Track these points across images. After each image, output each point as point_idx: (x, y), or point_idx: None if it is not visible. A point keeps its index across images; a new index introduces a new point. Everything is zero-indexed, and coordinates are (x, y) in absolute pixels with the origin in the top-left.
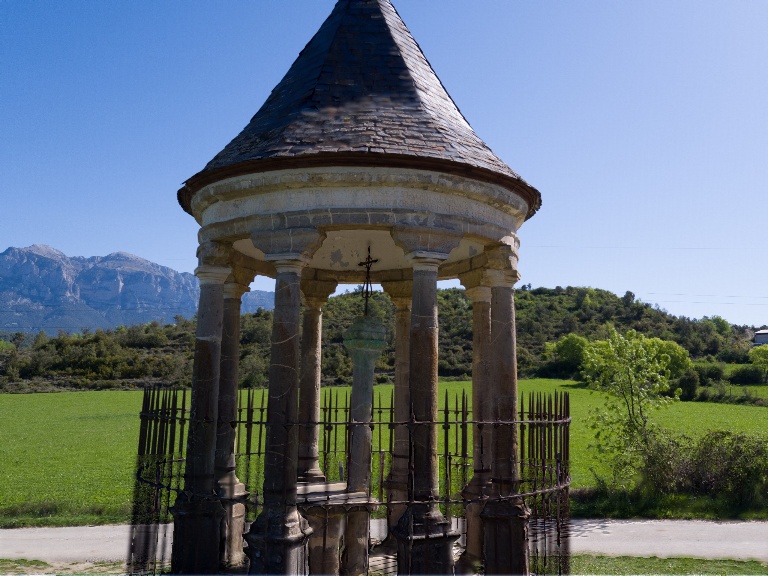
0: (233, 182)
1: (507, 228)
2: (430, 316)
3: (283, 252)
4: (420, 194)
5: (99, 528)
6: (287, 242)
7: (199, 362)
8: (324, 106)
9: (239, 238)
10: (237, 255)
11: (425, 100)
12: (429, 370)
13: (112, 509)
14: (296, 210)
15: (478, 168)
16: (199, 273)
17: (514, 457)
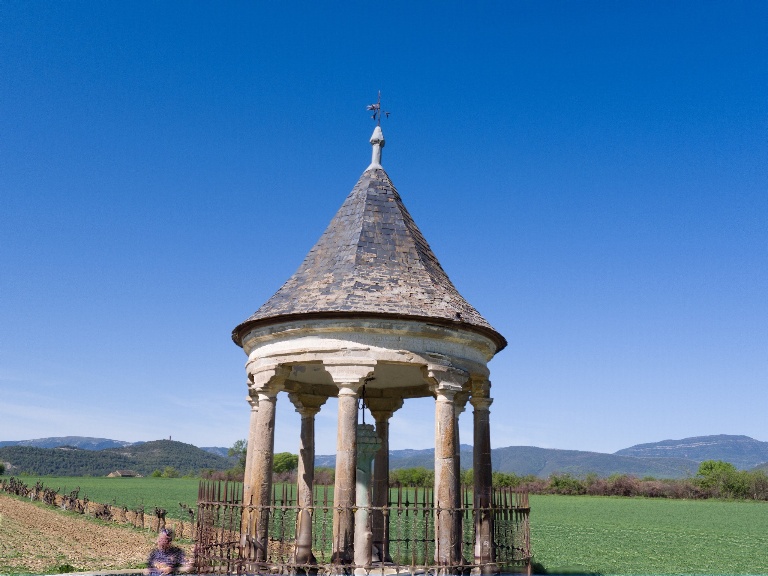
0: None
1: None
2: None
3: None
4: None
5: None
6: None
7: None
8: None
9: (423, 395)
10: None
11: None
12: None
13: None
14: None
15: None
16: None
17: None
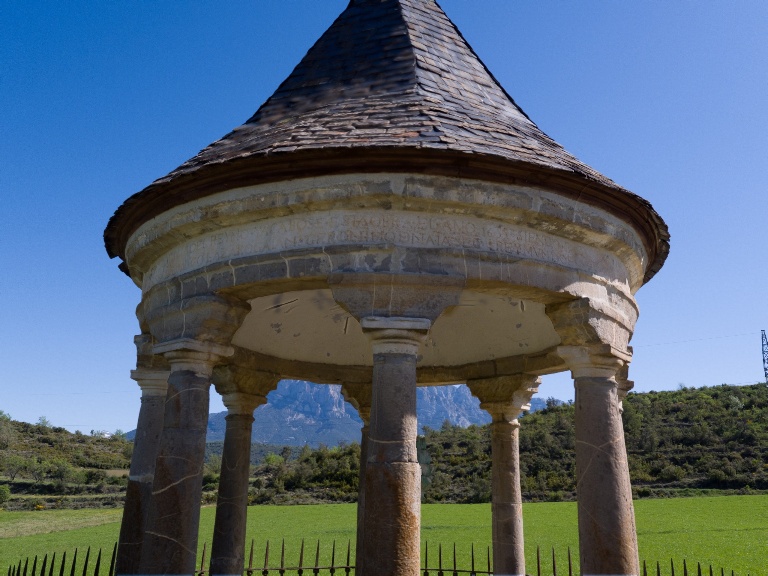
0: (133, 241)
1: (585, 269)
2: (395, 440)
3: (173, 339)
4: (378, 217)
5: None
6: (179, 322)
7: (125, 515)
8: (270, 116)
9: None
10: (242, 354)
11: (429, 82)
12: (390, 551)
13: None
14: (192, 269)
15: (480, 157)
16: (137, 381)
17: None
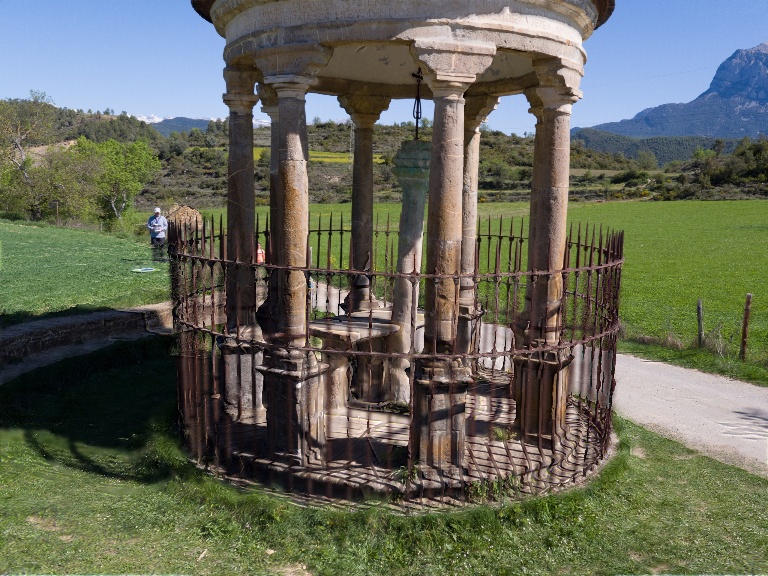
0: None
1: (427, 15)
2: (284, 148)
3: None
4: (274, 8)
5: (485, 326)
6: None
7: None
8: None
9: (259, 79)
10: (356, 85)
11: None
12: (283, 207)
13: (517, 313)
14: None
15: None
16: None
17: (436, 312)
